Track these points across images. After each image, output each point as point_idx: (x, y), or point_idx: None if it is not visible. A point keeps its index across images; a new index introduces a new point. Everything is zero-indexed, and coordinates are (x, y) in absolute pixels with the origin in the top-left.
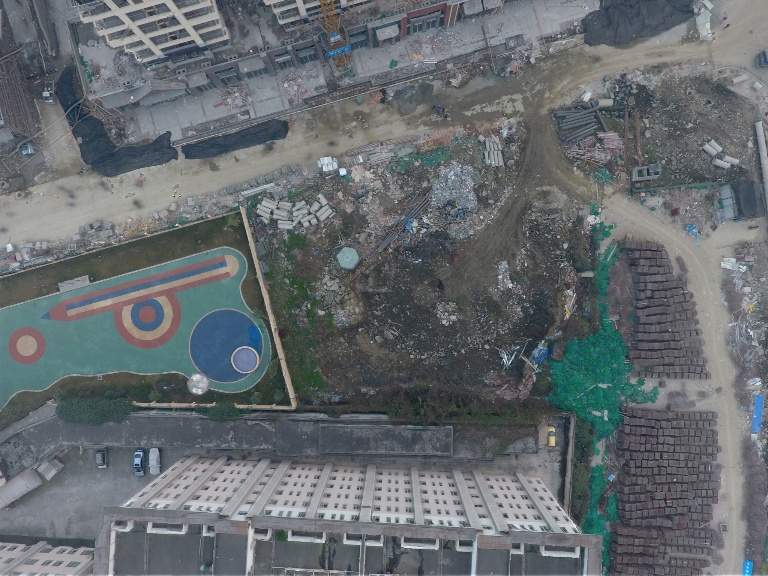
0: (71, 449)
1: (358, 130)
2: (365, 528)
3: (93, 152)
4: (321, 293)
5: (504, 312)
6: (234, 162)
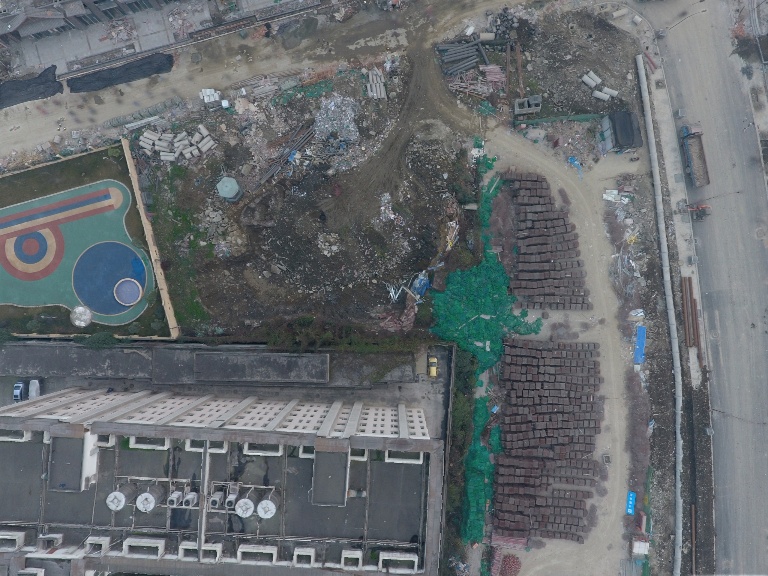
0: None
1: (243, 64)
2: (205, 434)
3: None
4: (204, 225)
5: (390, 245)
6: (119, 95)
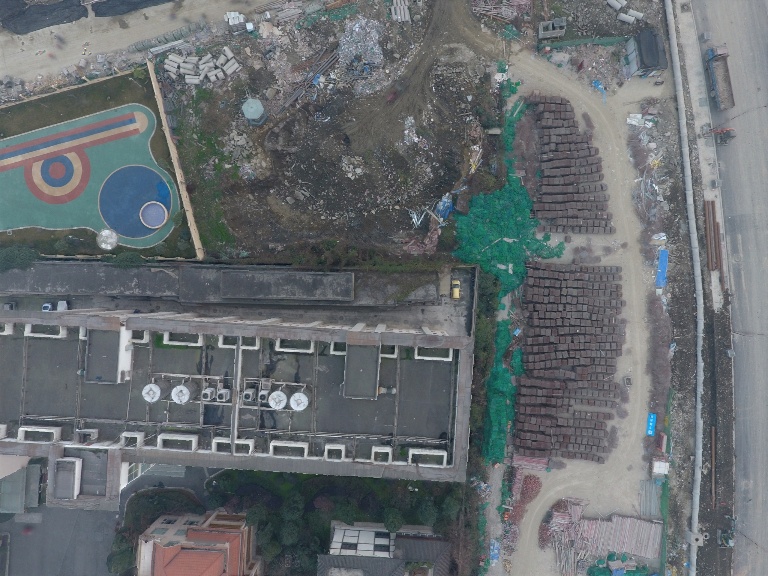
0: None
1: None
2: (238, 329)
3: (3, 9)
4: (229, 149)
5: (413, 170)
6: (143, 20)
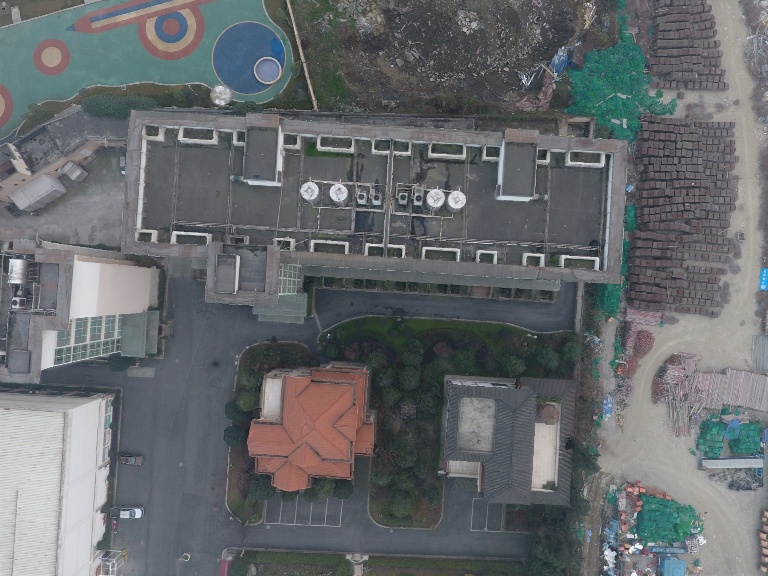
0: (95, 157)
1: None
2: (393, 132)
3: None
4: (343, 5)
5: (524, 30)
6: None
